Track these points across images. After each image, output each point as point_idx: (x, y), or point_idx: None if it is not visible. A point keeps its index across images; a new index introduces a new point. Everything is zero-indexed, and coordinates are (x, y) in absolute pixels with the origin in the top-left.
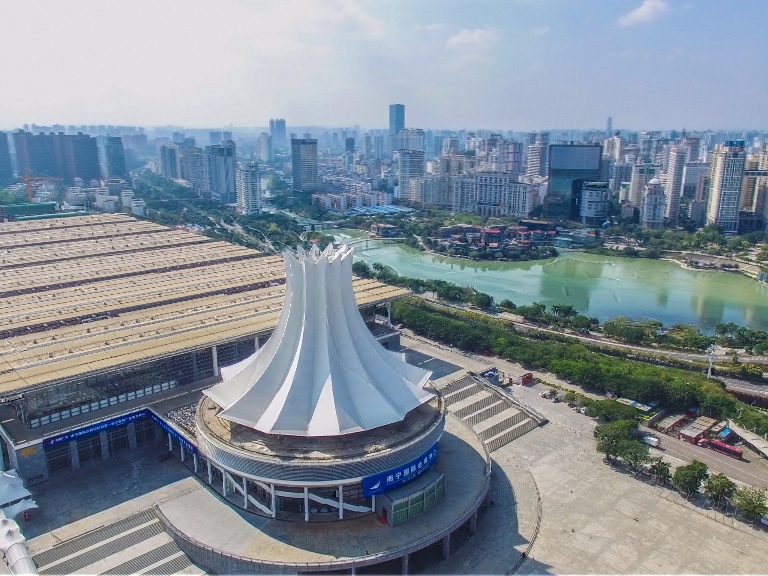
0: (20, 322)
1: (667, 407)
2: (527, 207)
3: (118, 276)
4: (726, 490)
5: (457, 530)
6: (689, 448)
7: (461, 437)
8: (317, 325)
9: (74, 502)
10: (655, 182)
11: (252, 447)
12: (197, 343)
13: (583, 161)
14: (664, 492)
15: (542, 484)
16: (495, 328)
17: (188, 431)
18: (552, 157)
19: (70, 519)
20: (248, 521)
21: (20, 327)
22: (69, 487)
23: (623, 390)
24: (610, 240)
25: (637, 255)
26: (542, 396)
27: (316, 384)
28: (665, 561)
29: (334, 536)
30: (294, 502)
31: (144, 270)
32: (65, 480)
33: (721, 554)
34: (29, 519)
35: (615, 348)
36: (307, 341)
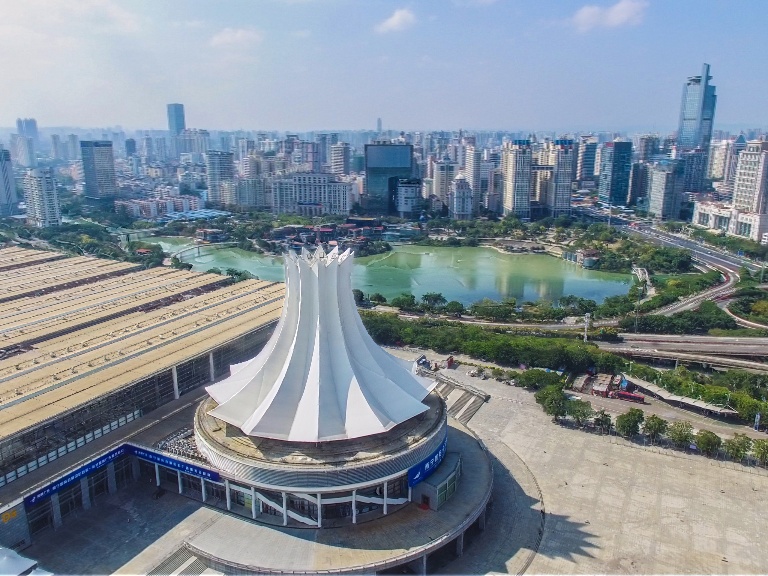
0: None
1: (573, 370)
2: (348, 205)
3: None
4: (660, 428)
5: None
6: (604, 401)
7: None
8: (329, 328)
9: (84, 561)
10: (461, 178)
11: (294, 460)
12: (165, 365)
13: (397, 160)
14: (612, 439)
15: (518, 450)
16: (393, 320)
17: (197, 458)
18: (368, 156)
19: None
20: (297, 536)
21: None
22: (65, 547)
23: (536, 360)
24: (432, 232)
25: (459, 244)
26: (471, 375)
27: (339, 387)
28: (645, 492)
29: (391, 531)
30: (336, 508)
31: (15, 294)
32: (53, 541)
33: (678, 478)
34: None
35: (496, 327)
36: (323, 345)
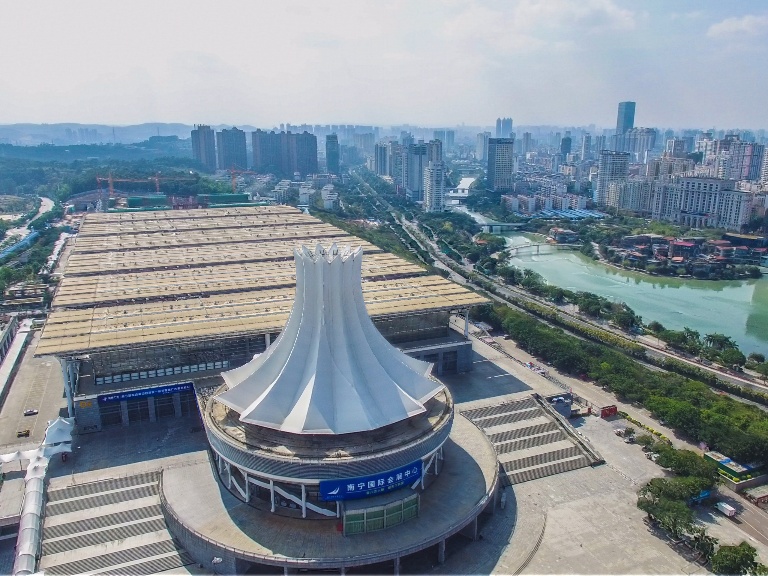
0: (131, 294)
1: None
2: (740, 219)
3: (240, 262)
4: None
5: (425, 556)
6: None
7: (478, 461)
8: (315, 323)
9: (106, 453)
10: None
11: (233, 431)
12: (245, 329)
13: None
14: (699, 572)
15: (552, 529)
16: (608, 351)
17: None
18: None
19: (94, 467)
20: (223, 500)
21: (127, 298)
22: (111, 440)
23: (717, 442)
24: None
25: None
26: (616, 433)
27: (304, 381)
28: None
29: (286, 532)
30: (268, 491)
31: (264, 258)
32: (112, 434)
33: None
34: (66, 460)
35: (758, 392)
36: (303, 338)
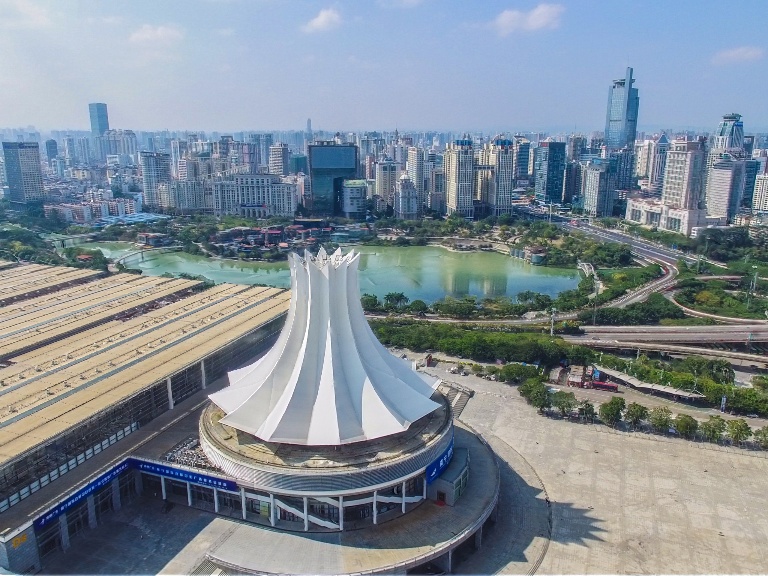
0: None
1: (547, 363)
2: (293, 206)
3: None
4: None
5: None
6: (580, 391)
7: None
8: (339, 330)
9: None
10: (405, 178)
11: (316, 464)
12: (163, 374)
13: (341, 160)
14: (597, 427)
15: (512, 443)
16: None
17: (210, 468)
18: (312, 157)
19: None
20: (321, 541)
21: None
22: (79, 569)
23: (512, 355)
24: (380, 232)
25: (409, 244)
26: (451, 372)
27: (352, 389)
28: (638, 476)
29: (413, 529)
30: (356, 510)
31: None
32: (64, 564)
33: (665, 461)
34: None
35: (462, 324)
36: (335, 347)
